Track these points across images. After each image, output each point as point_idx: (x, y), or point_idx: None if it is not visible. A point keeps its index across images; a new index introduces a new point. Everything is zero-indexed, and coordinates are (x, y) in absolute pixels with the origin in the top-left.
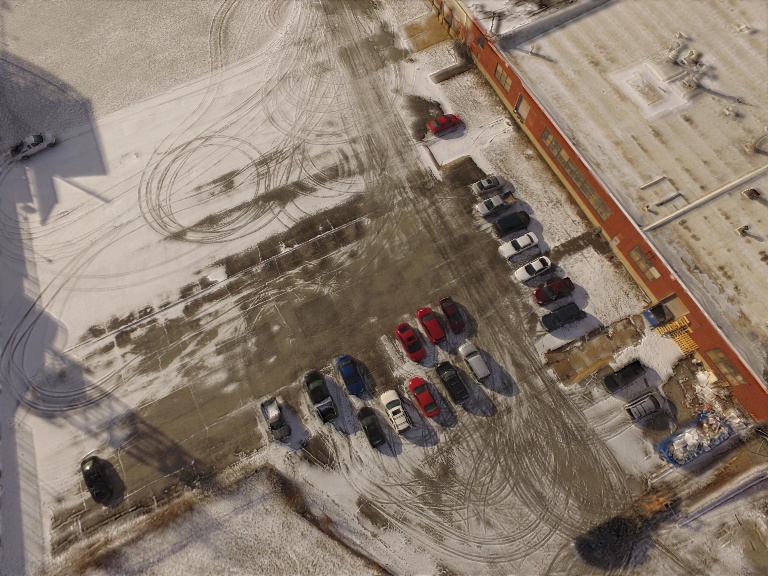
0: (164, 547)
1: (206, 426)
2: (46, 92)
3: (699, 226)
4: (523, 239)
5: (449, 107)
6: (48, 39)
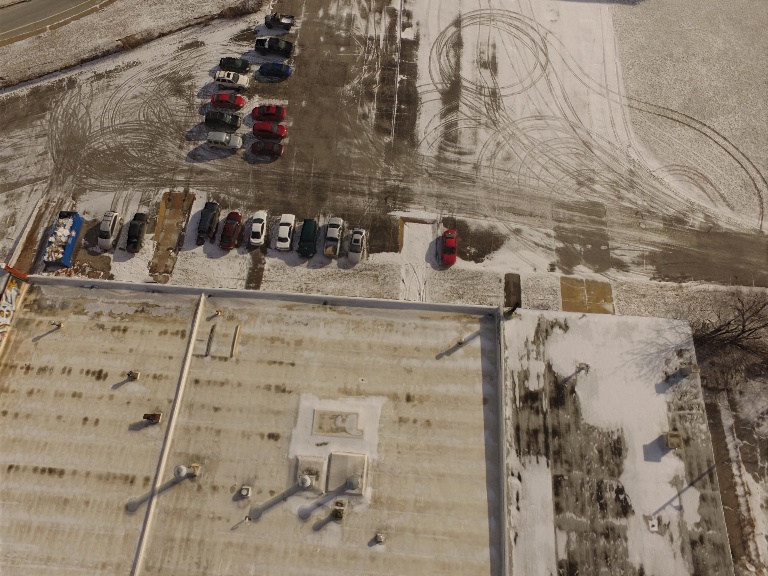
0: None
1: None
2: None
3: (169, 345)
4: (285, 232)
5: (467, 269)
6: (737, 2)
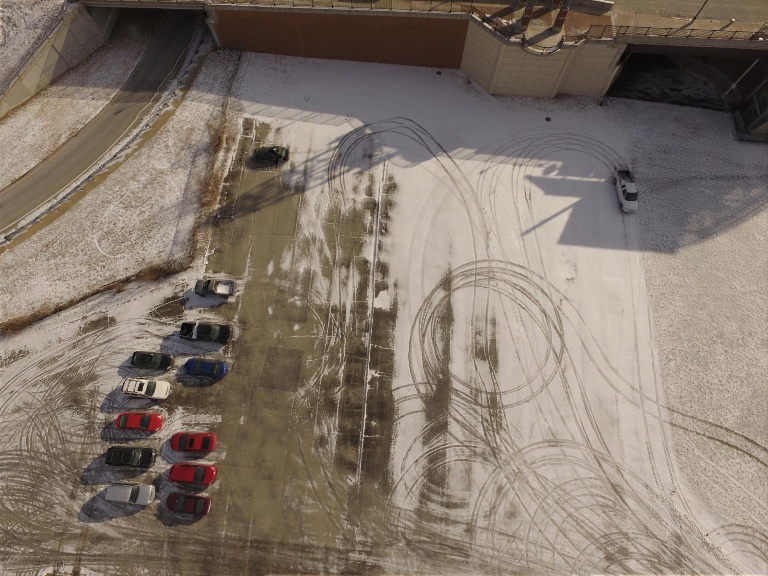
0: (190, 179)
1: (252, 236)
2: (707, 222)
3: None
4: None
5: None
6: None
